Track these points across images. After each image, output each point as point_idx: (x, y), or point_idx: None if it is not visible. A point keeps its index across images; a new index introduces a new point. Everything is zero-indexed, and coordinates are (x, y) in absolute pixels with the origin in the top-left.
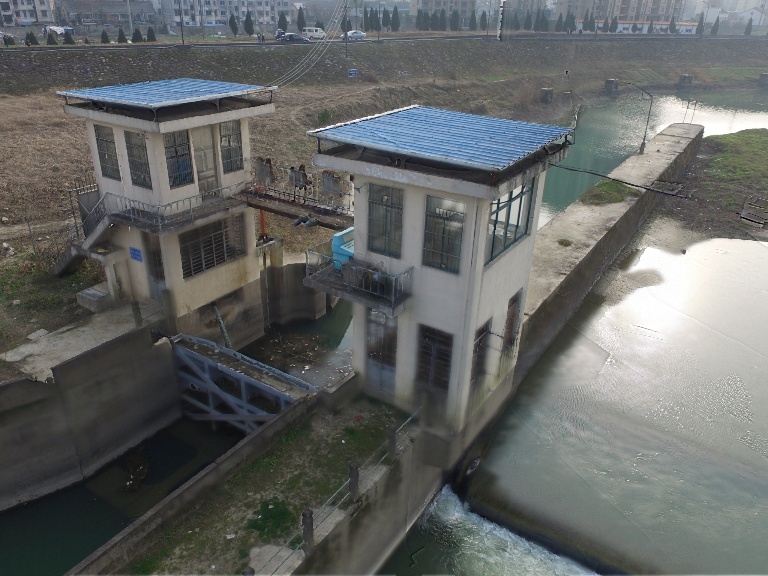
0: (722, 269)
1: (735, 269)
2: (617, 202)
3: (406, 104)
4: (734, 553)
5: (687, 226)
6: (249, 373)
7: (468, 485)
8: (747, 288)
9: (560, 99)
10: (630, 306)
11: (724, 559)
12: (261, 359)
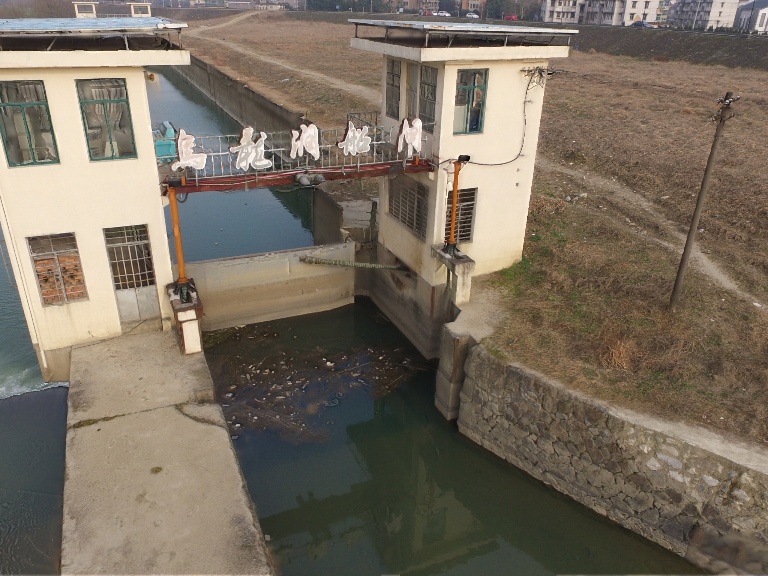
0: None
1: None
2: None
3: None
4: None
5: None
6: (265, 257)
7: (66, 388)
8: None
9: None
10: None
11: None
12: (376, 344)
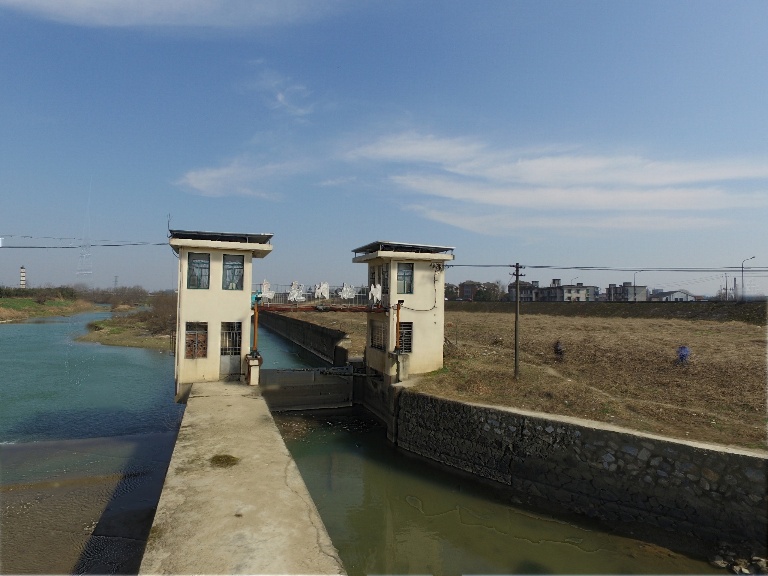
0: None
1: None
2: None
3: None
4: None
5: None
6: None
7: None
8: None
9: None
10: None
11: None
12: None
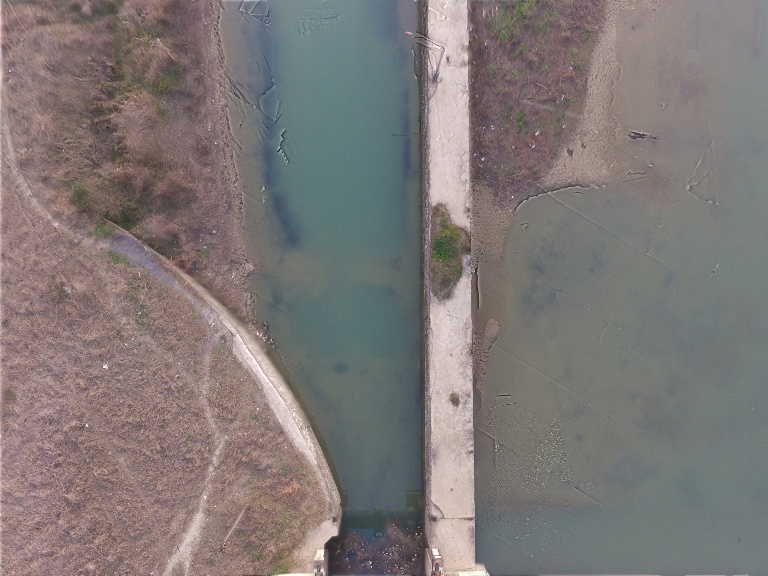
0: (529, 266)
1: (537, 259)
2: (459, 279)
3: (159, 132)
4: (569, 554)
5: (496, 201)
6: None
7: None
8: (548, 292)
9: (319, 5)
10: (490, 375)
11: (566, 559)
12: (345, 571)
